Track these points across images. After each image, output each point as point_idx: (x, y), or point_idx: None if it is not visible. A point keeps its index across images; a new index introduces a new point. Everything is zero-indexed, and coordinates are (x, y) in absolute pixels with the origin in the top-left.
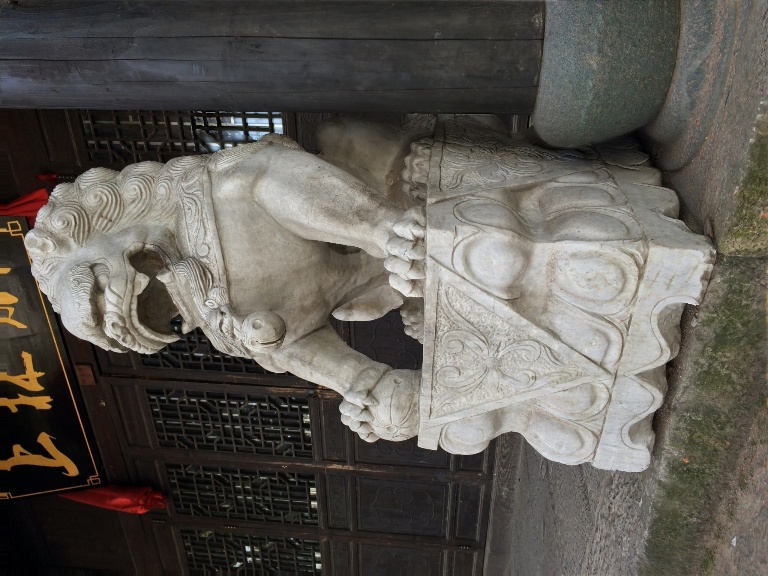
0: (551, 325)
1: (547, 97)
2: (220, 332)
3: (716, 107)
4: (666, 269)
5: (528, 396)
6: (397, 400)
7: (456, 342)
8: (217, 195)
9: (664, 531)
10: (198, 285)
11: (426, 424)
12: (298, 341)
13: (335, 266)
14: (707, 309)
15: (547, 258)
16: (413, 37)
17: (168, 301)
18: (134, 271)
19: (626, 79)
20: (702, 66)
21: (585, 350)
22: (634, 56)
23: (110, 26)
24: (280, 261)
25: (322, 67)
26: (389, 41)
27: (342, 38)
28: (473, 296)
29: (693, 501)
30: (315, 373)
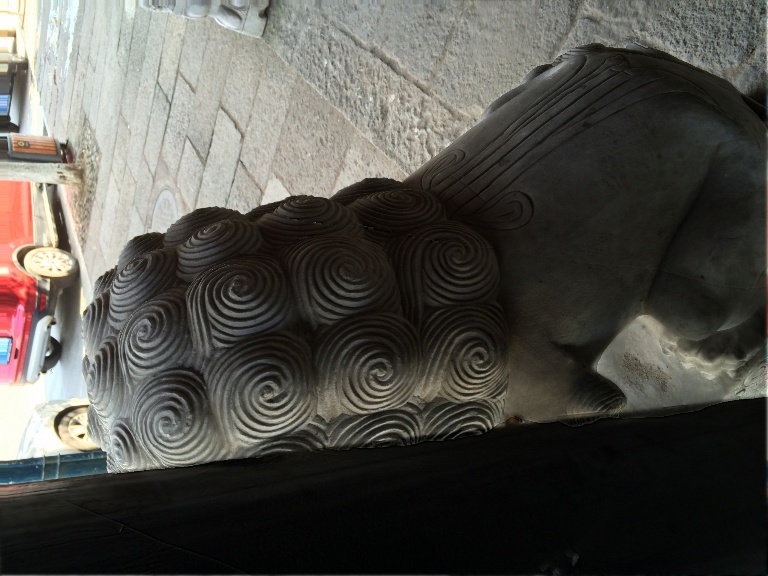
0: None
1: None
2: None
3: None
4: None
5: None
6: None
7: None
8: None
9: None
10: None
11: None
12: None
13: None
14: None
15: None
16: None
17: None
18: None
19: None
20: None
21: None
22: None
23: None
24: None
25: None
26: None
27: None
28: None
29: None
30: None
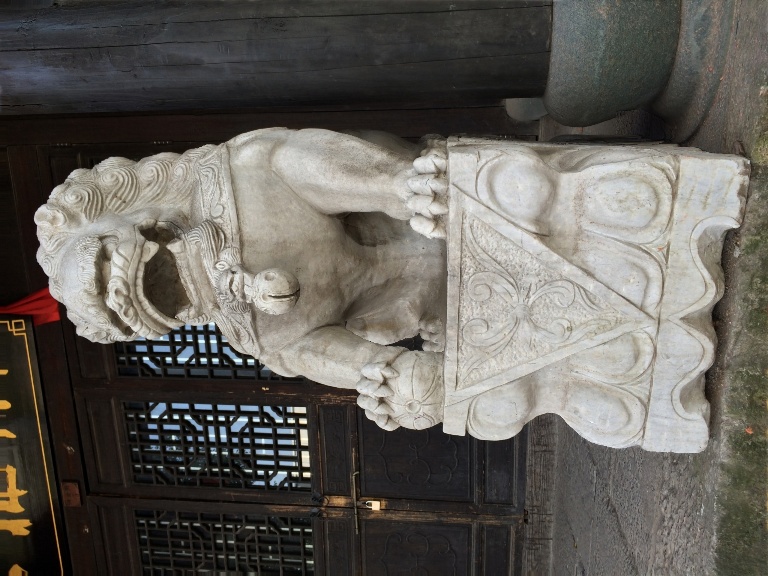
0: (584, 264)
1: (560, 56)
2: (230, 293)
3: (727, 43)
4: (700, 184)
5: (564, 353)
6: (419, 370)
7: (483, 287)
8: (235, 163)
9: (735, 535)
10: (210, 245)
11: (452, 398)
12: (310, 333)
13: (351, 252)
14: (749, 231)
15: (574, 191)
16: (429, 10)
17: (175, 293)
18: (144, 239)
19: (635, 30)
20: (707, 13)
21: (623, 289)
22: (641, 8)
23: (144, 15)
24: (296, 228)
25: (342, 42)
26: (406, 14)
27: (362, 14)
28: (499, 229)
29: (764, 489)
30: (328, 362)
